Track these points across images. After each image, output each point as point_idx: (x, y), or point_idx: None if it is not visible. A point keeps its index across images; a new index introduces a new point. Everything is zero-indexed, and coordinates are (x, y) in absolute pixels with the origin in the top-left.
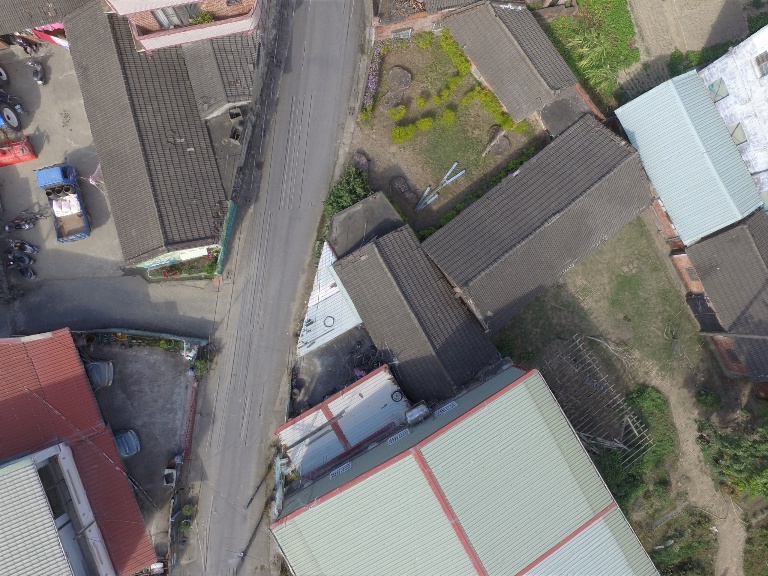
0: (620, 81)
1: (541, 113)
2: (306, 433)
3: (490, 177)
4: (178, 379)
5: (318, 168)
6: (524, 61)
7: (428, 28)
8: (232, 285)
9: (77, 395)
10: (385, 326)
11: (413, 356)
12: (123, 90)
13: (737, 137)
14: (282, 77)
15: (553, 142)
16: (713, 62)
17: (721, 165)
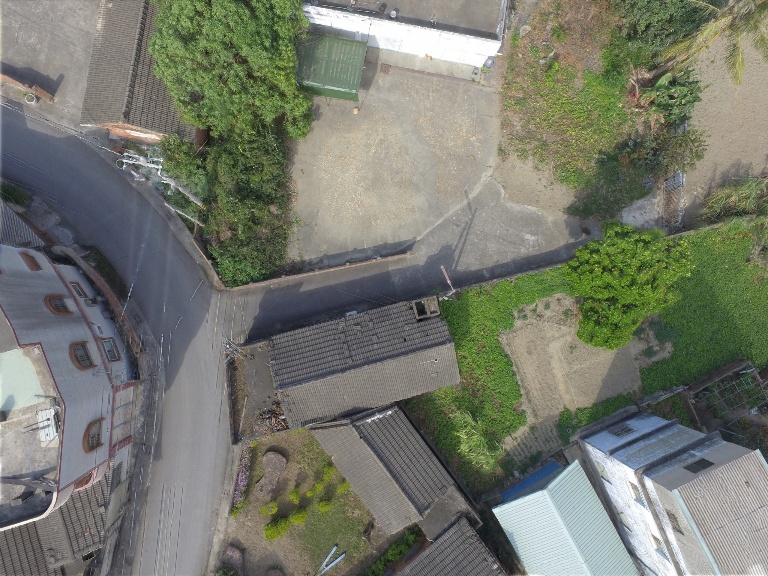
0: (506, 447)
1: None
2: None
3: (371, 559)
4: None
5: (191, 559)
6: (391, 482)
7: None
8: None
9: None
10: None
11: None
12: None
13: (624, 519)
14: (152, 465)
15: (428, 549)
16: (595, 449)
17: (602, 570)
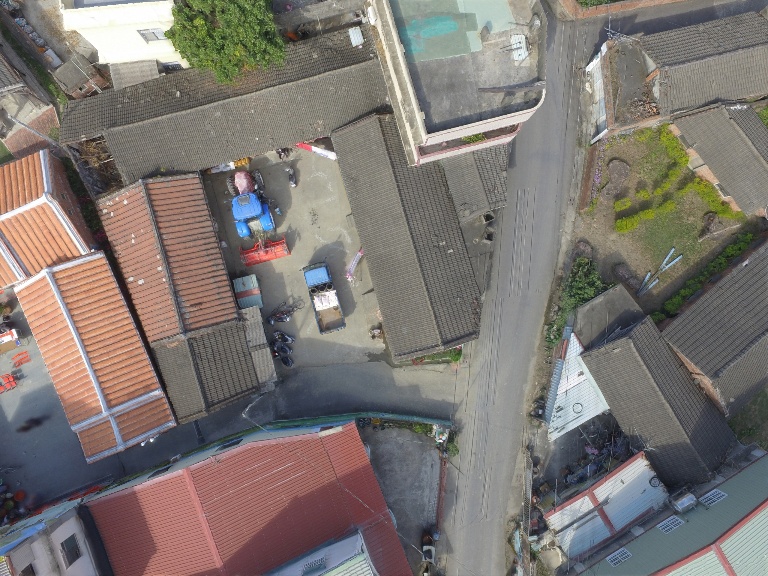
0: None
1: (767, 205)
2: (573, 518)
3: (706, 261)
4: (424, 458)
5: (543, 256)
6: (757, 160)
7: (650, 125)
8: (469, 369)
9: (365, 484)
10: (635, 413)
11: (664, 442)
12: (397, 201)
13: None
14: (507, 172)
15: None
16: None
17: None
